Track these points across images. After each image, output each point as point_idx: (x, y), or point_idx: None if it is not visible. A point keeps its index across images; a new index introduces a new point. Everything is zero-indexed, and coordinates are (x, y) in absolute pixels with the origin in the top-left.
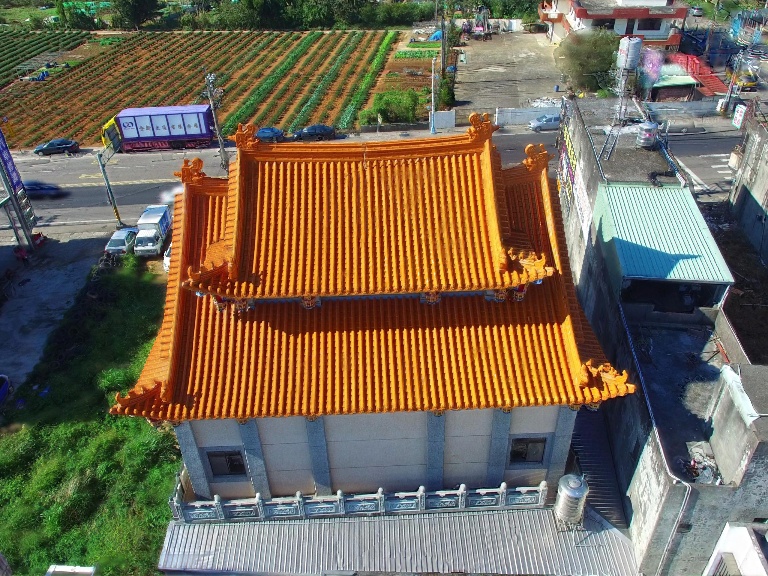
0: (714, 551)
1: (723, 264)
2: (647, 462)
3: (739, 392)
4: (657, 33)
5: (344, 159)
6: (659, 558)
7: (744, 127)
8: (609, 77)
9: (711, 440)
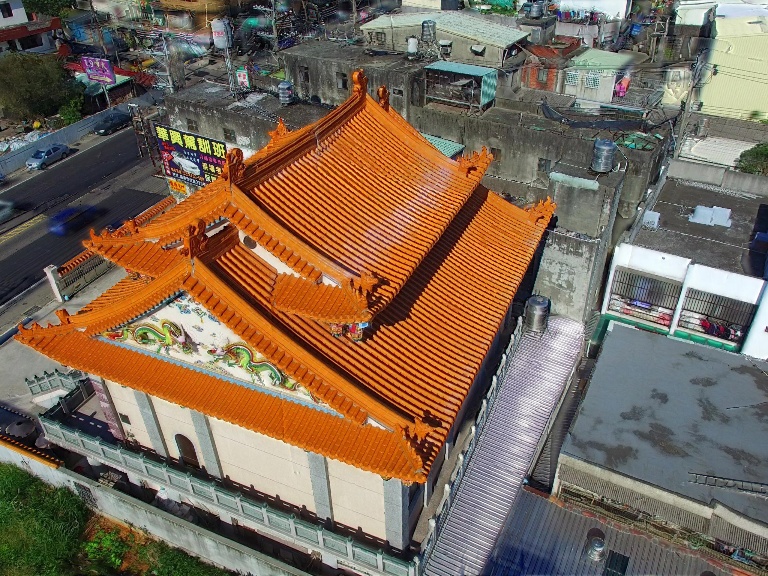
0: (612, 271)
1: (446, 141)
2: (555, 256)
3: (575, 179)
4: (44, 48)
5: (301, 154)
6: (587, 304)
7: (253, 86)
8: (148, 75)
9: (559, 224)
